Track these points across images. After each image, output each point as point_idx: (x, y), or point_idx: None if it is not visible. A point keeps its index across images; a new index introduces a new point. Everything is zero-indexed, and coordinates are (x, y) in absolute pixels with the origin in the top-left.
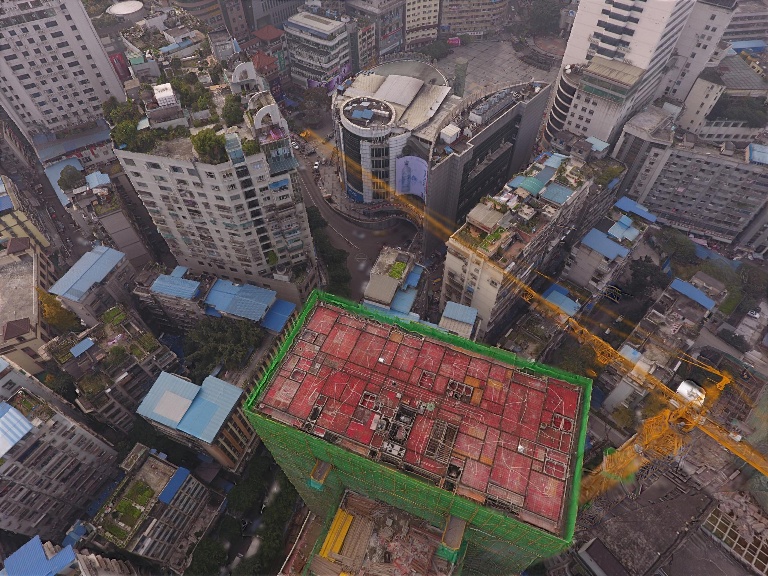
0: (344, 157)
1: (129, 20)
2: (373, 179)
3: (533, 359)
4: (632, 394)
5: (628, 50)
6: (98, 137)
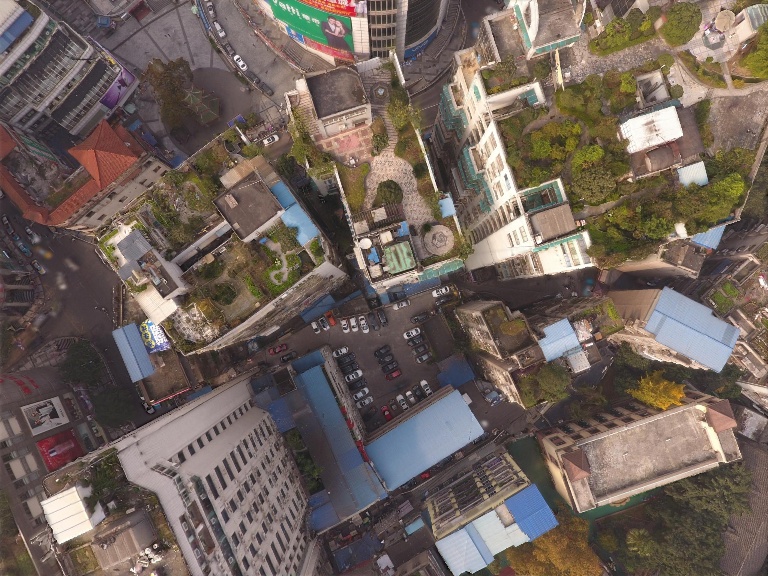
0: None
1: None
2: None
3: None
4: None
5: None
6: (331, 417)
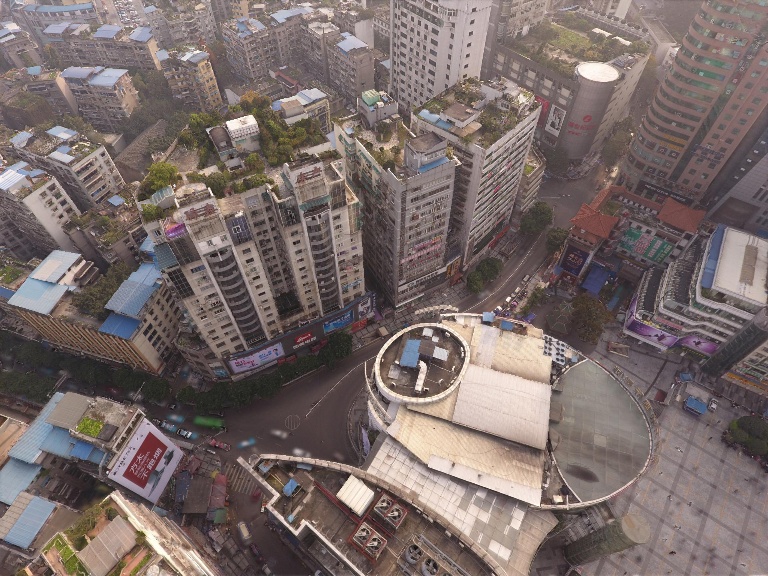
0: None
1: (580, 83)
2: None
3: None
4: None
5: None
6: None
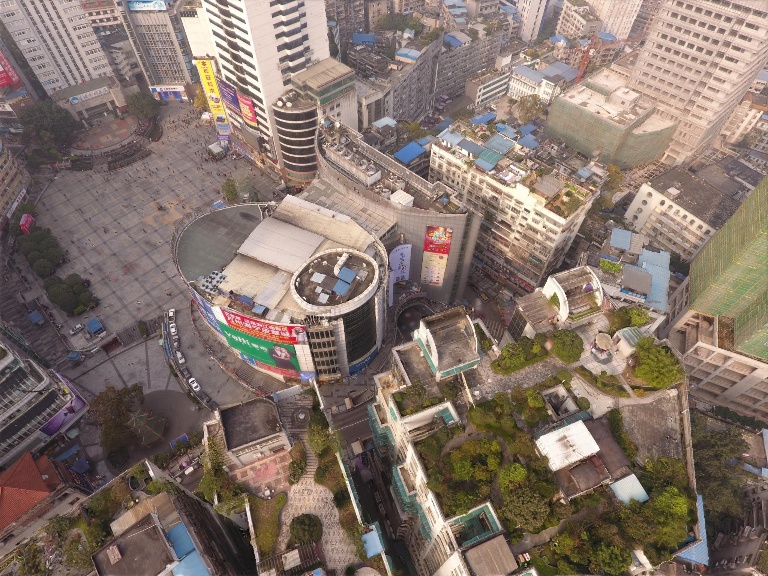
0: (345, 345)
1: None
2: (385, 317)
3: (610, 221)
4: None
5: (312, 52)
6: None
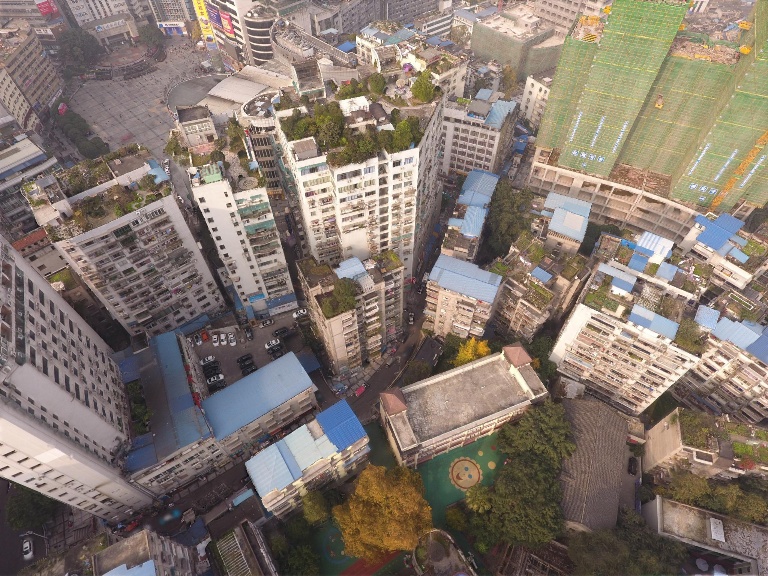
0: None
1: None
2: None
3: None
4: (500, 82)
5: None
6: (173, 368)
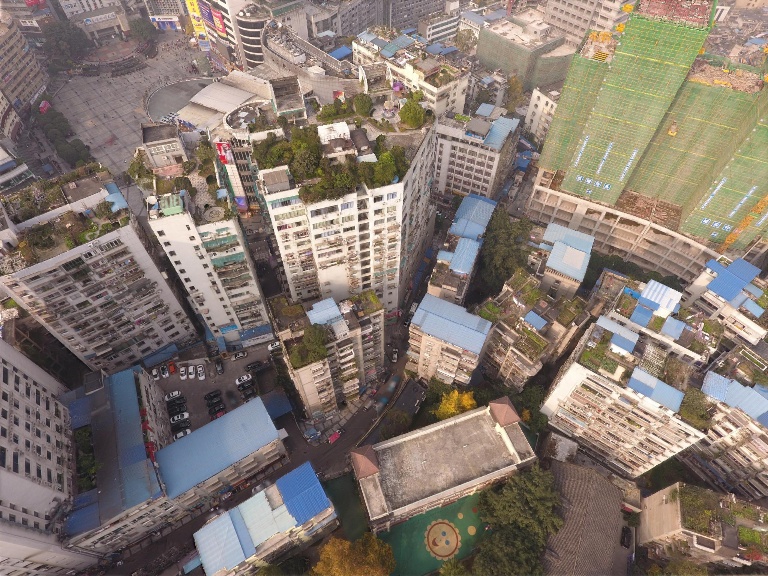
0: None
1: None
2: None
3: None
4: (504, 93)
5: None
6: (127, 413)
